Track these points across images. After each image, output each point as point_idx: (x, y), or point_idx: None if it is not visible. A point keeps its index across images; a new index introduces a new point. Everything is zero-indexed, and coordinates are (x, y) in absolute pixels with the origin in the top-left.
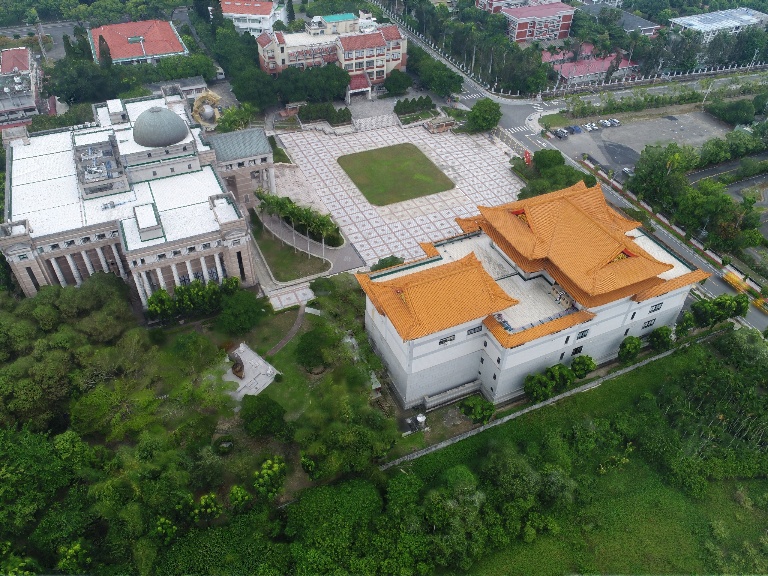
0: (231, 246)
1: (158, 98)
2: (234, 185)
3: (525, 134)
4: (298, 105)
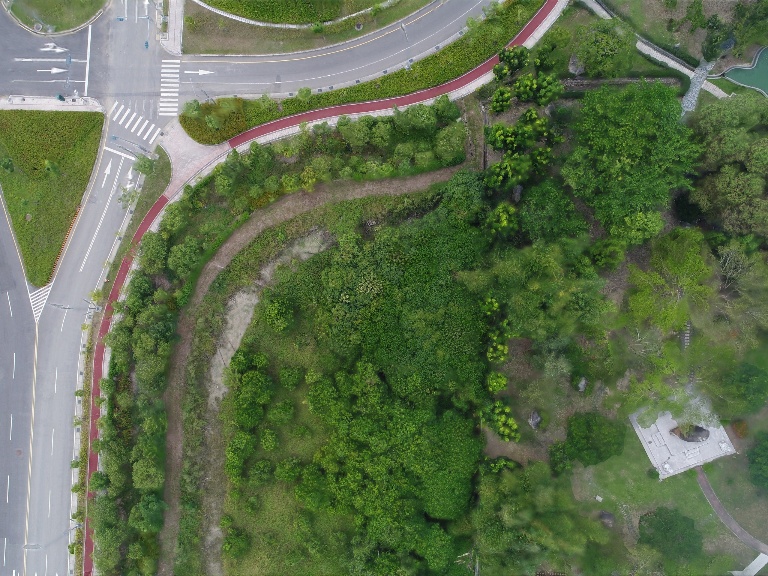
0: None
1: None
2: None
3: None
4: None
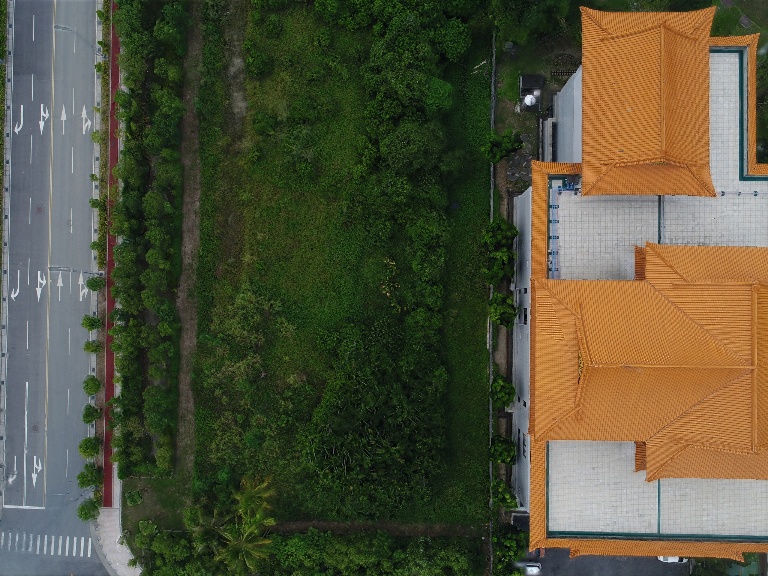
0: None
1: None
2: None
3: None
4: None
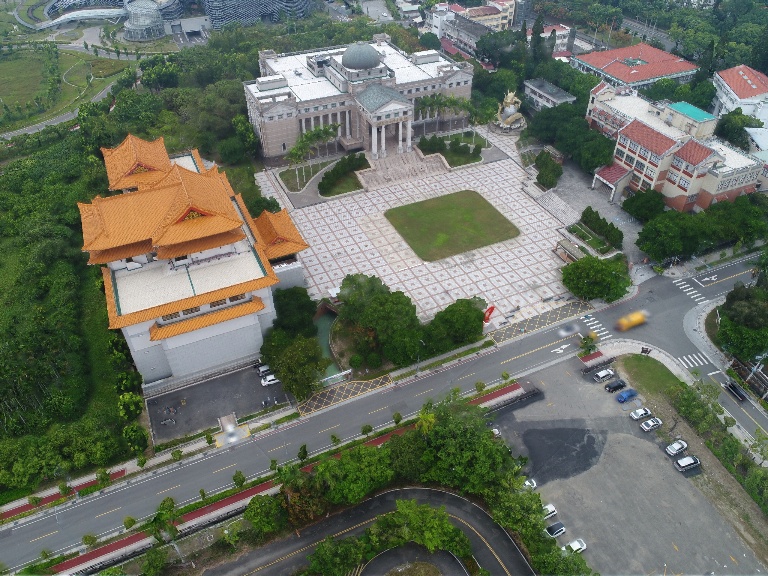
0: (258, 117)
1: (460, 68)
2: (395, 138)
3: (584, 333)
4: (552, 151)
